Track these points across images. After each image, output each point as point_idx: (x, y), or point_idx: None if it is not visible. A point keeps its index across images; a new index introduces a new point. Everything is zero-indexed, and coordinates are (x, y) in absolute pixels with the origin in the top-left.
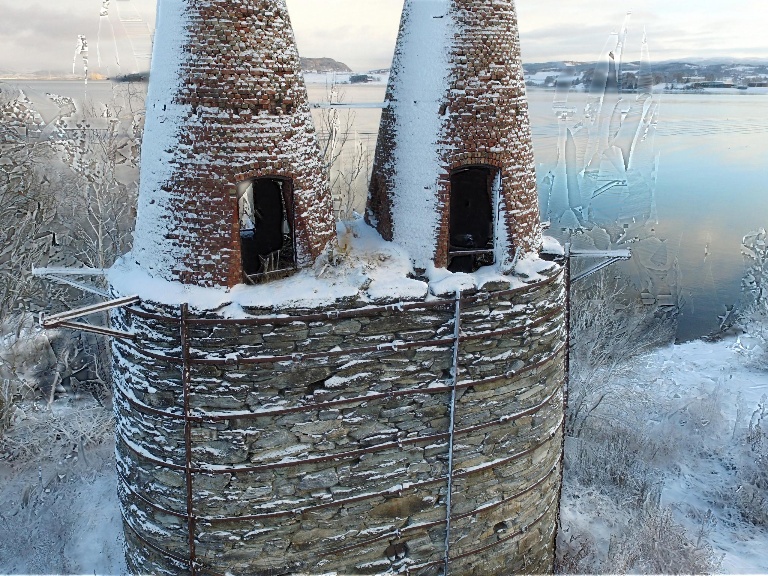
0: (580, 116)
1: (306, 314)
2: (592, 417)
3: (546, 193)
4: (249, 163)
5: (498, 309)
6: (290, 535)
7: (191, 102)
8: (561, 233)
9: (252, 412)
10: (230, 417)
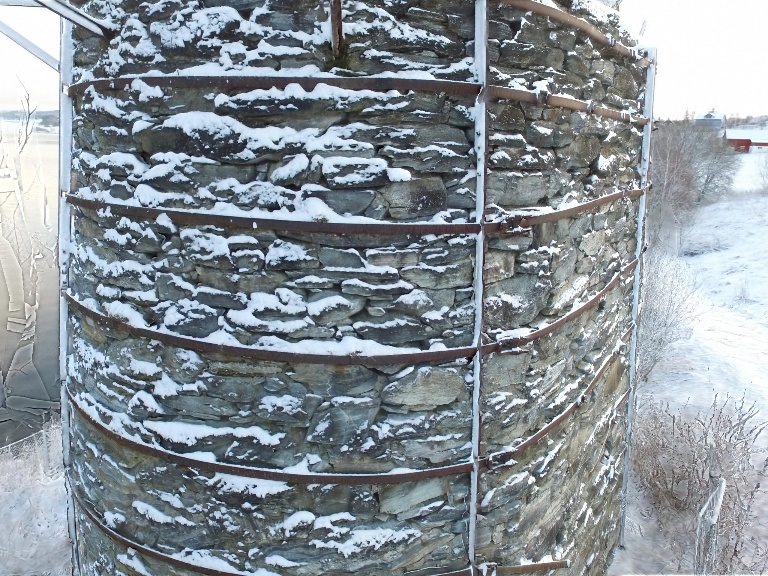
0: None
1: None
2: None
3: None
4: None
5: None
6: (566, 451)
7: None
8: None
9: (556, 209)
10: (538, 219)
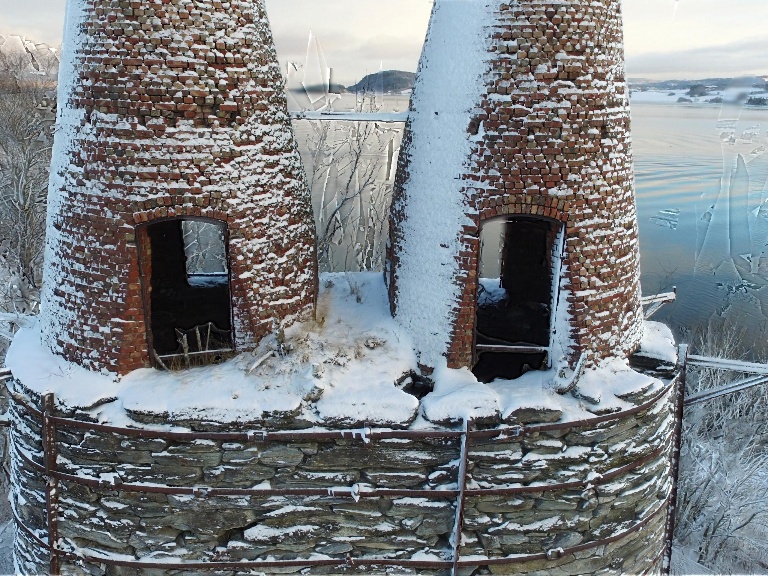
0: (762, 139)
1: (215, 430)
2: (736, 538)
3: (705, 232)
4: (156, 197)
5: (538, 451)
6: None
7: (85, 105)
8: (716, 288)
9: (136, 559)
10: (106, 561)
